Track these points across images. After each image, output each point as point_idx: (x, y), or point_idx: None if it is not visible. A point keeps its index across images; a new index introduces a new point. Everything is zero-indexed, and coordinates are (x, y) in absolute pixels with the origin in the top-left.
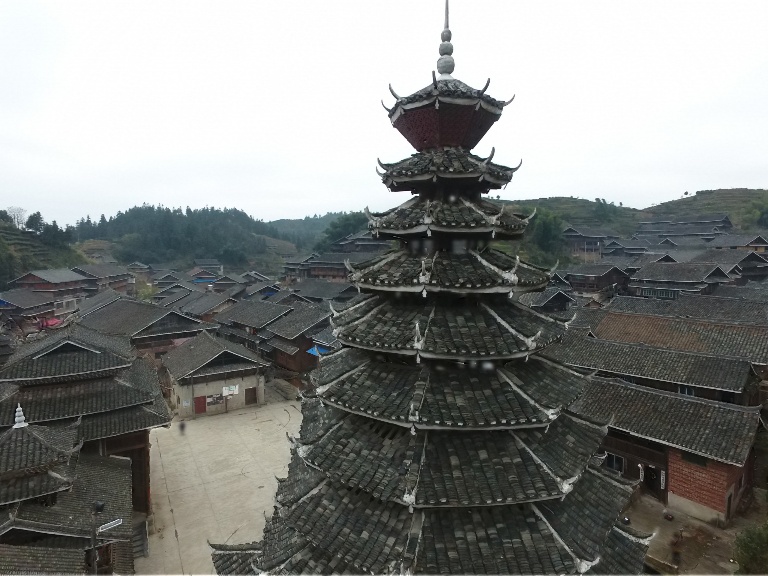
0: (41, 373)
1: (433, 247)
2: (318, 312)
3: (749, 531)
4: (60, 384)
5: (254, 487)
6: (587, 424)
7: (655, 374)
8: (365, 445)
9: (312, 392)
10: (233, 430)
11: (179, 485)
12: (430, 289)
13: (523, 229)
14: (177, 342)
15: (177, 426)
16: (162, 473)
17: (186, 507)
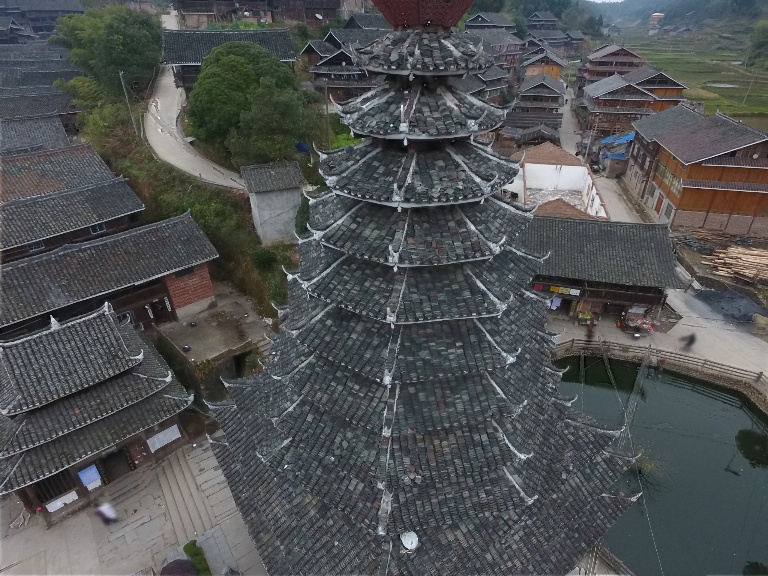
0: None
1: None
2: None
3: (276, 284)
4: None
5: None
6: None
7: (67, 226)
8: (505, 316)
9: None
10: None
11: None
12: None
13: None
14: None
15: None
16: None
17: None
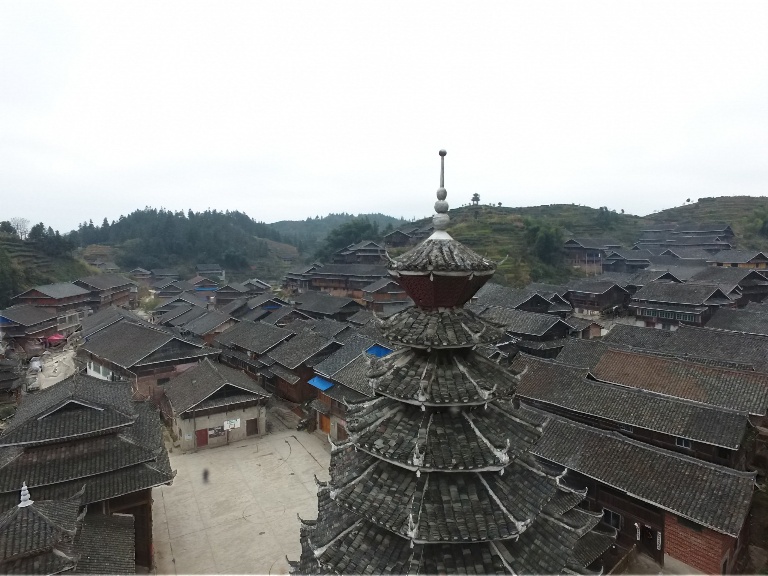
0: (45, 435)
1: (428, 410)
2: (319, 340)
3: None
4: (64, 443)
5: (255, 533)
6: (577, 575)
7: (653, 425)
8: None
9: (313, 422)
10: (234, 465)
11: (181, 530)
12: (424, 470)
13: (515, 386)
14: (179, 368)
15: (179, 460)
16: (164, 516)
17: (188, 556)
